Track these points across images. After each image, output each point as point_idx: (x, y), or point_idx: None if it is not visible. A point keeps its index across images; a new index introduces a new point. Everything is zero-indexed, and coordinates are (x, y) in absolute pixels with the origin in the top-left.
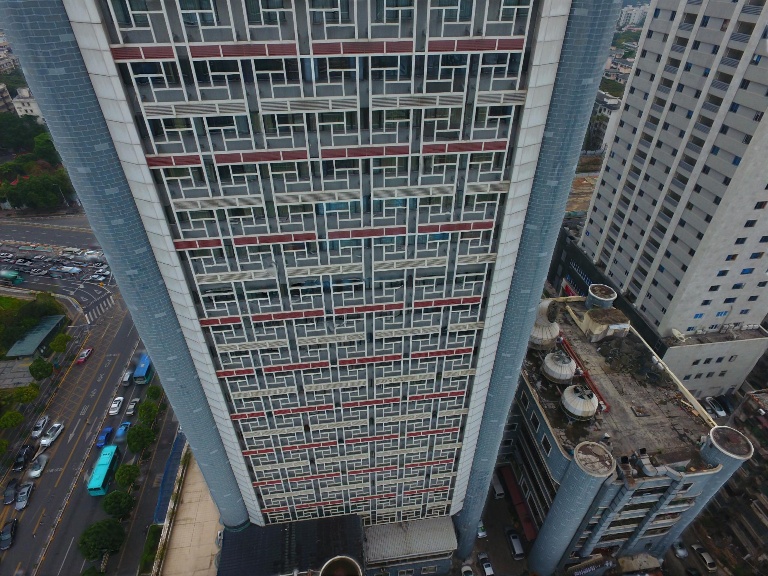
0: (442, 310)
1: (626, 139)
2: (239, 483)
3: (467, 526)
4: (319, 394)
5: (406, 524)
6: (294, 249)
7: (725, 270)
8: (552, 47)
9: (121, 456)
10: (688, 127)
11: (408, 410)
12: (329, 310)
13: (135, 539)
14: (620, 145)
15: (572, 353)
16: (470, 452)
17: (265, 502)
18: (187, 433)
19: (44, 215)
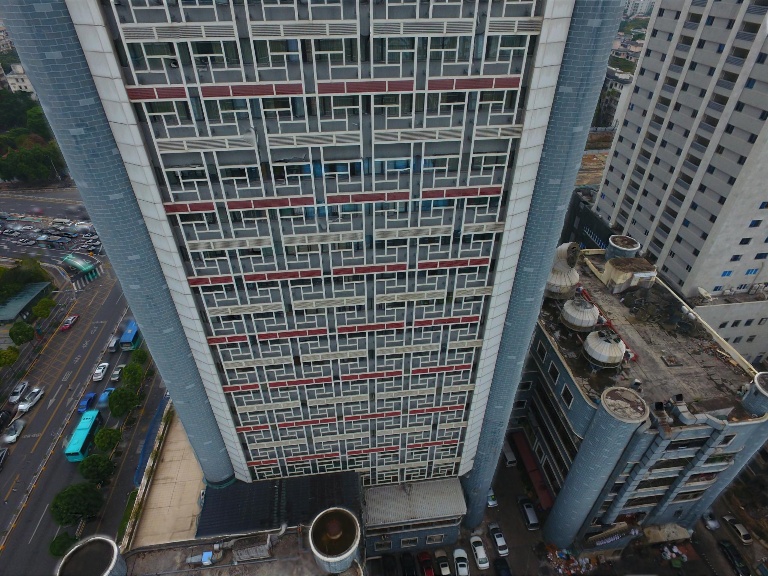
0: (455, 204)
1: (647, 87)
2: (221, 429)
3: (477, 489)
4: (310, 314)
5: (410, 487)
6: (276, 107)
7: (758, 220)
8: None
9: (103, 422)
10: (719, 62)
11: (413, 339)
12: (321, 201)
13: (114, 506)
14: (640, 95)
15: (593, 303)
16: (483, 397)
17: (251, 453)
18: (158, 360)
19: (35, 189)
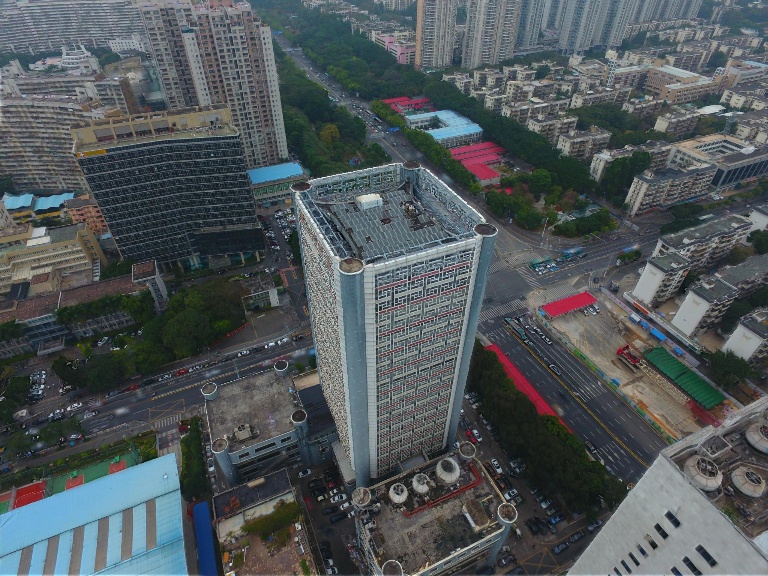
0: None
1: None
2: None
3: None
4: None
5: None
6: None
7: None
8: (342, 331)
9: None
10: None
11: None
12: None
13: None
14: None
15: (445, 497)
16: (352, 444)
17: None
18: None
19: (494, 216)
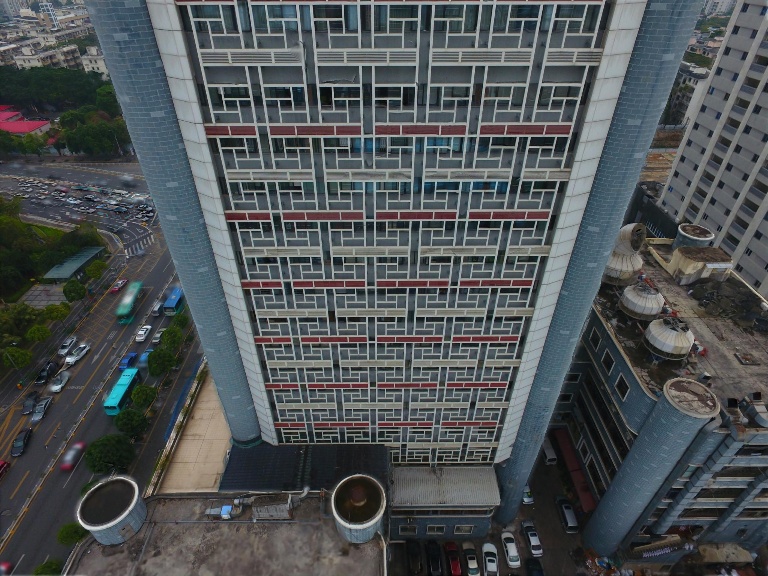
0: (516, 144)
1: (732, 68)
2: (250, 384)
3: (513, 481)
4: (349, 263)
5: (440, 471)
6: (328, 17)
7: None
8: None
9: (142, 381)
10: None
11: (457, 301)
12: None
13: (145, 461)
14: (723, 77)
15: None
16: (528, 376)
17: (279, 413)
18: (191, 302)
19: (99, 162)
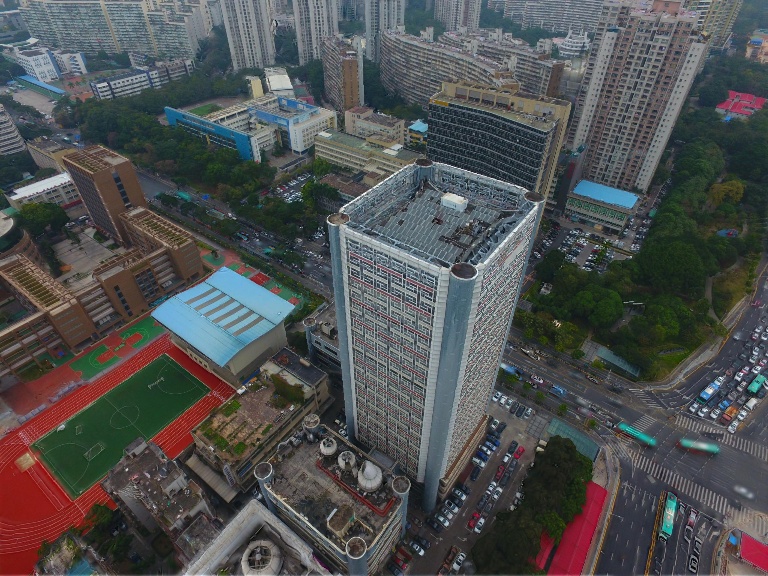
0: None
1: None
2: None
3: None
4: None
5: None
6: None
7: None
8: None
9: None
10: None
11: None
12: None
13: None
14: None
15: (349, 489)
16: None
17: None
18: None
19: None
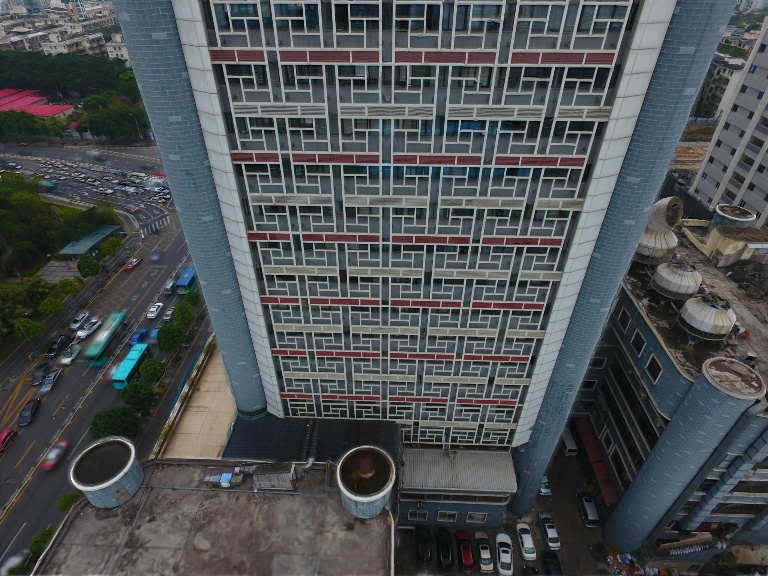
0: (552, 75)
1: None
2: (256, 350)
3: (531, 468)
4: (362, 214)
5: (454, 454)
6: None
7: None
8: None
9: (151, 356)
10: None
11: (479, 261)
12: None
13: (151, 436)
14: (767, 54)
15: None
16: (553, 351)
17: (286, 382)
18: (194, 255)
19: (119, 146)
